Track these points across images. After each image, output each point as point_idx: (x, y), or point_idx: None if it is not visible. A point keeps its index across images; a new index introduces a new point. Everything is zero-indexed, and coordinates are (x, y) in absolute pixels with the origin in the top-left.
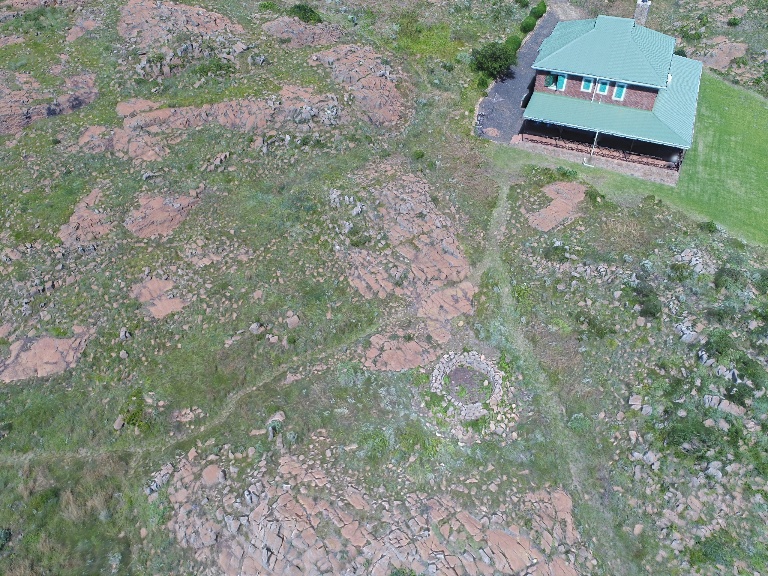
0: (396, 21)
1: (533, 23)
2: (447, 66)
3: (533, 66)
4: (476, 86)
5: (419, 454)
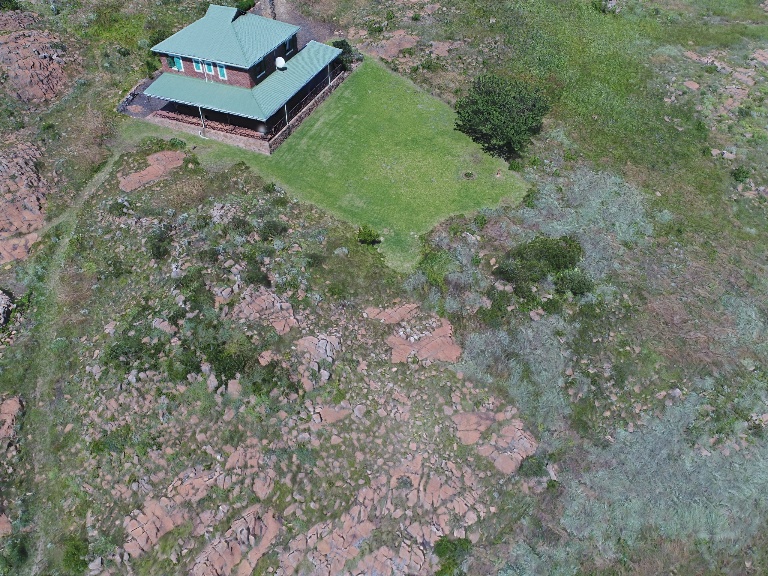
0: (95, 11)
1: None
2: (122, 51)
3: (151, 49)
4: (147, 70)
5: None
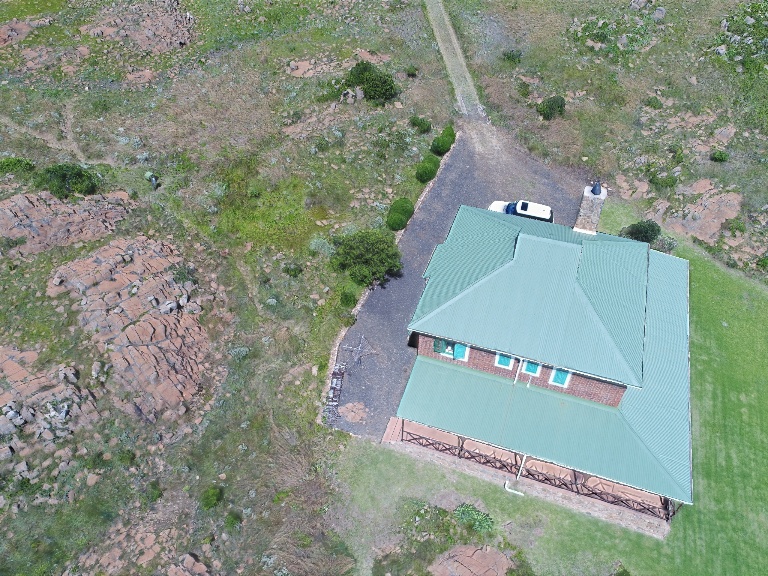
0: (221, 179)
1: (434, 168)
2: (291, 269)
3: (410, 328)
4: (338, 301)
5: None
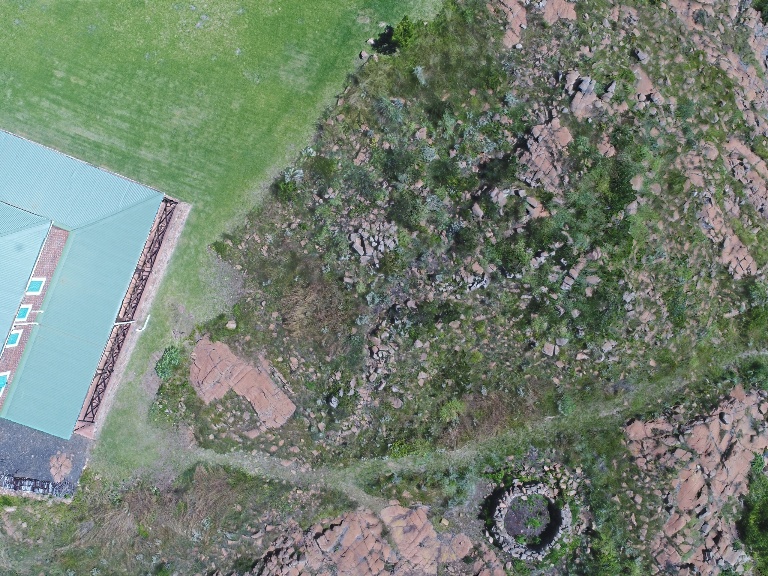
0: None
1: None
2: None
3: None
4: None
5: (618, 574)
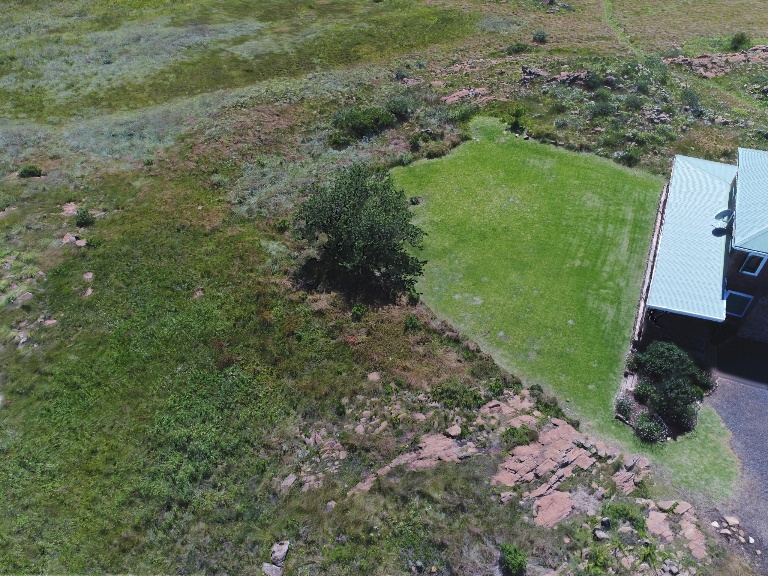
0: None
1: None
2: None
3: None
4: None
5: None
